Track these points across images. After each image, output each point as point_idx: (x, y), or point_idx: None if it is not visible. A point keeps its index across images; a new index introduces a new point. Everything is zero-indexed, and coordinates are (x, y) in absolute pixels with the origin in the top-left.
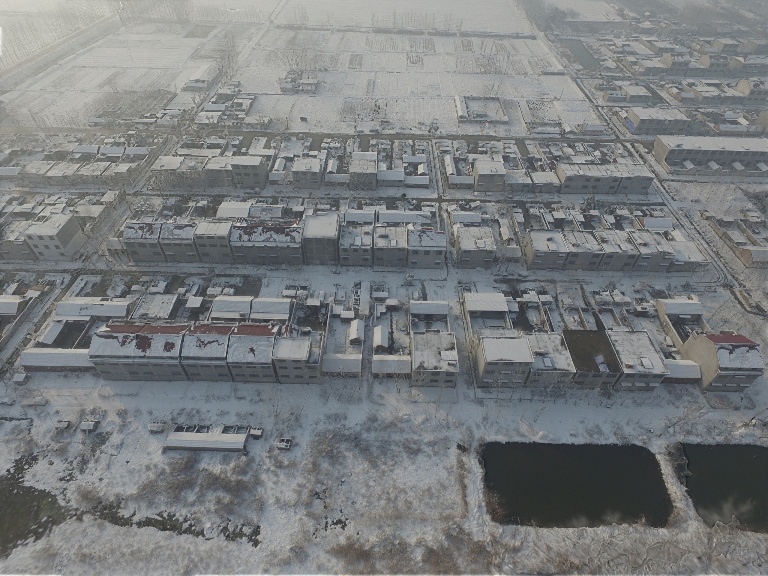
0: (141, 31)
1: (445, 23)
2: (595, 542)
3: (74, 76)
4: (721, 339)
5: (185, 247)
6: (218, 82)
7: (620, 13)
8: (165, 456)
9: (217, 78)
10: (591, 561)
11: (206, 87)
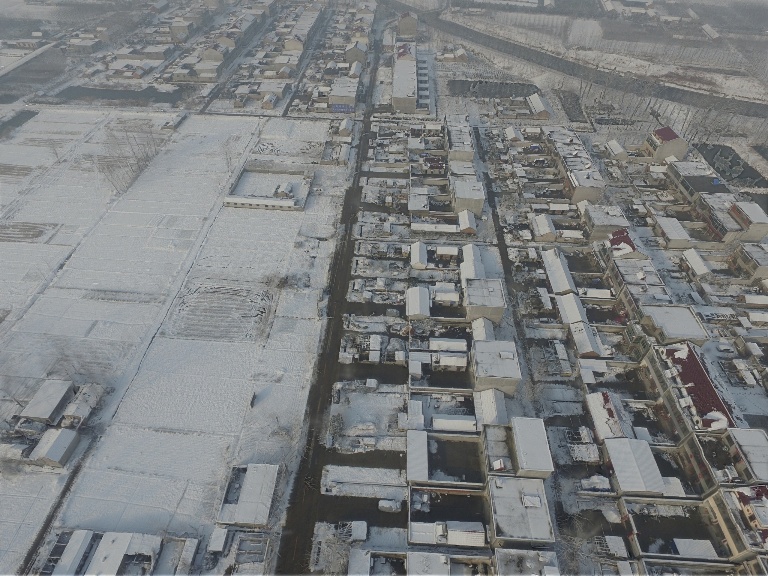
0: None
1: None
2: None
3: None
4: (669, 136)
5: None
6: None
7: (5, 46)
8: None
9: None
10: None
11: None
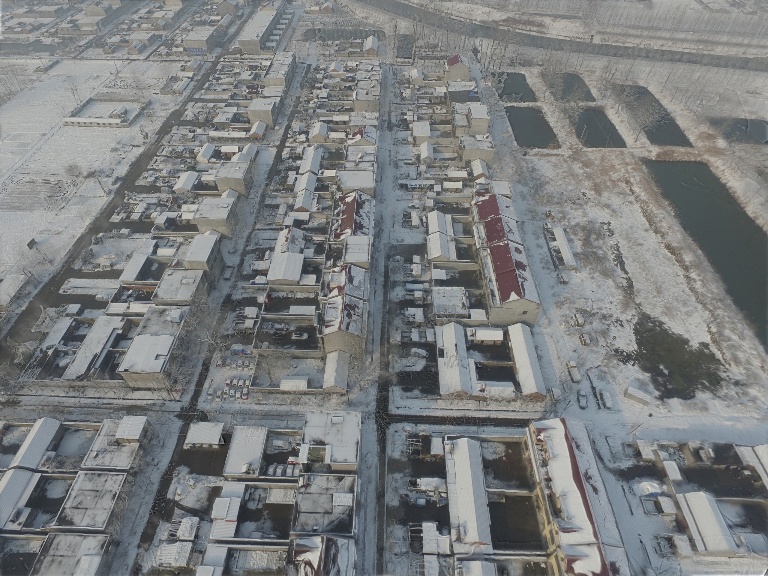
0: None
1: None
2: (558, 124)
3: None
4: (454, 62)
5: None
6: None
7: None
8: (581, 270)
9: None
10: None
11: None
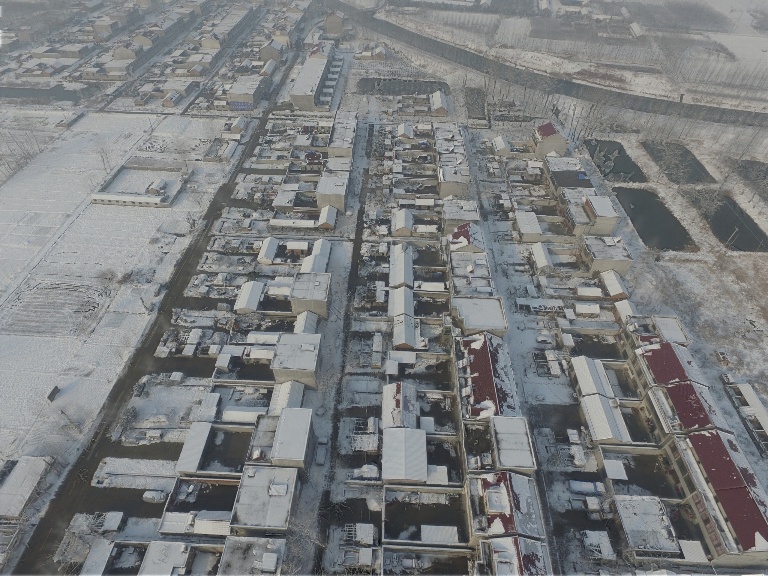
0: None
1: None
2: (686, 216)
3: None
4: (549, 132)
5: None
6: None
7: None
8: None
9: None
10: (716, 208)
11: None
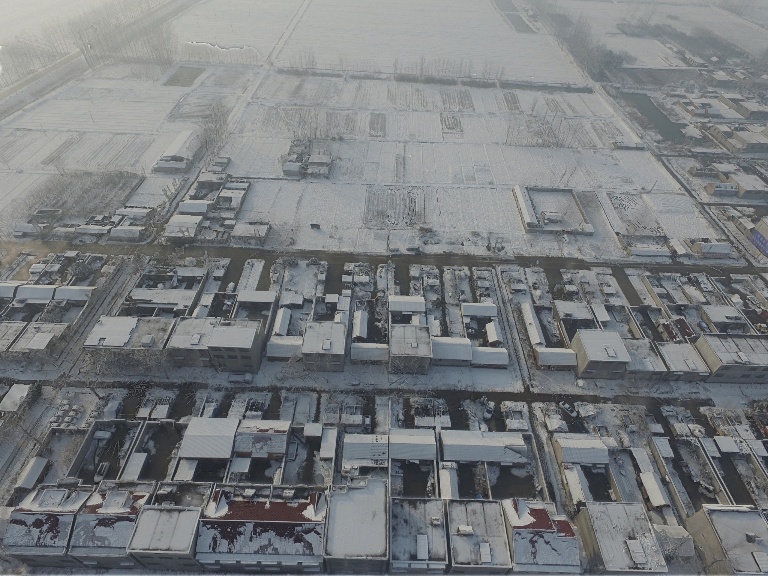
0: (111, 75)
1: (484, 72)
2: None
3: (13, 145)
4: None
5: (116, 557)
6: (201, 157)
7: (681, 56)
8: None
9: (200, 151)
10: None
11: (184, 168)
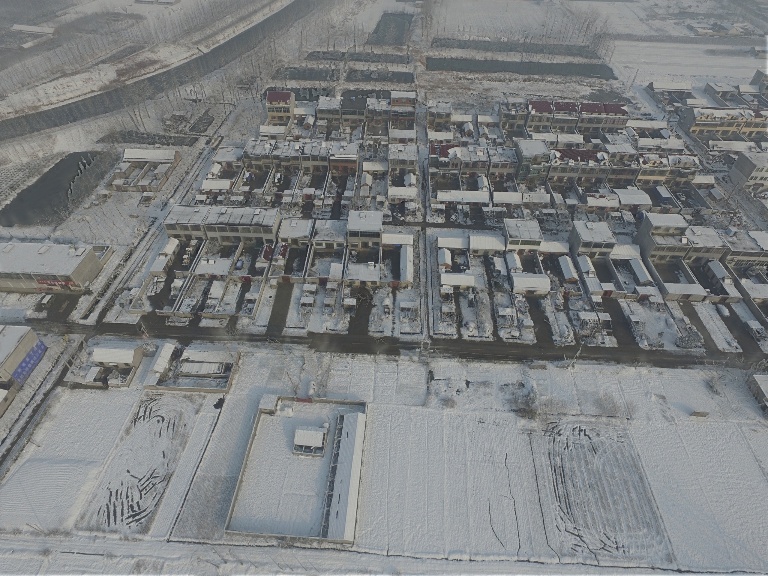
0: None
1: None
2: None
3: None
4: (283, 96)
5: None
6: None
7: None
8: None
9: None
10: None
11: None
